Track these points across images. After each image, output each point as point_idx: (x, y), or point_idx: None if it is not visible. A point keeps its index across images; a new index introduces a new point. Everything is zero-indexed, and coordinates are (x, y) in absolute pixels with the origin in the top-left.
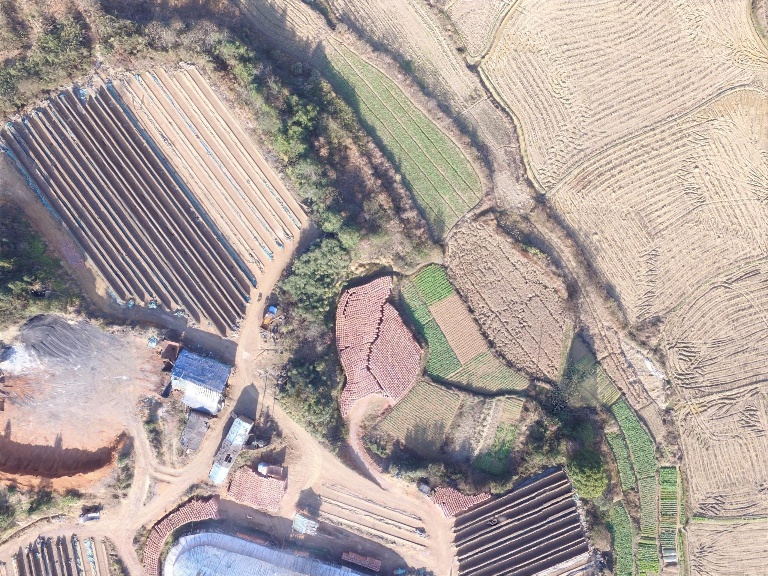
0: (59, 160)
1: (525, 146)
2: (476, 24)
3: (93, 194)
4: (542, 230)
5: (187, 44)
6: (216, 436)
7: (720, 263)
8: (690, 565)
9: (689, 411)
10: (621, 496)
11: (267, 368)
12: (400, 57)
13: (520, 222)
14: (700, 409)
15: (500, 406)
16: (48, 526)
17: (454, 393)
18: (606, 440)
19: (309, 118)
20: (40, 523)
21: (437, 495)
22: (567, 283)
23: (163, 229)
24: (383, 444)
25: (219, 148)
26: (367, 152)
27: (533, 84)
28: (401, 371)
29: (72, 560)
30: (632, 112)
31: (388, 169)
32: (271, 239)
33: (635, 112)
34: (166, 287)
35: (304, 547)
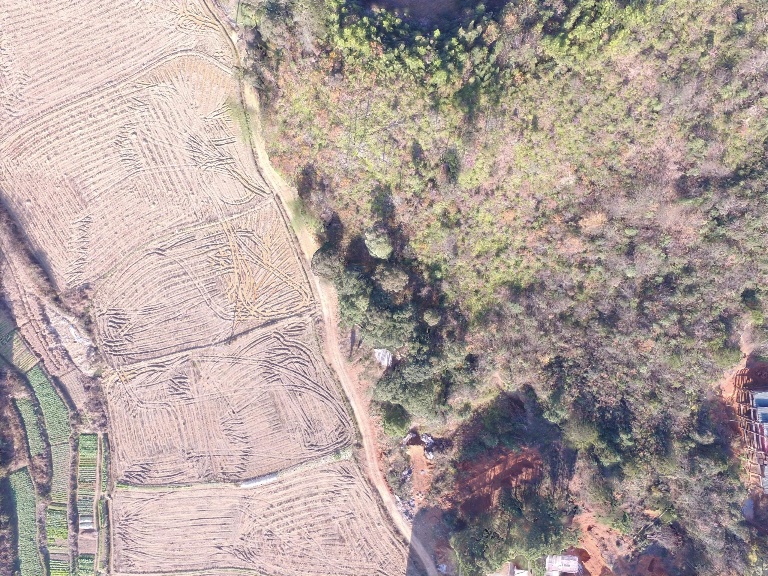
0: None
1: None
2: None
3: None
4: None
5: None
6: None
7: (154, 230)
8: (115, 533)
9: (118, 378)
10: (26, 462)
11: None
12: None
13: None
14: (129, 376)
15: None
16: None
17: None
18: (13, 406)
19: None
20: None
21: None
22: None
23: None
24: None
25: None
26: None
27: None
28: None
29: None
30: (70, 79)
31: None
32: None
33: (73, 78)
34: None
35: None
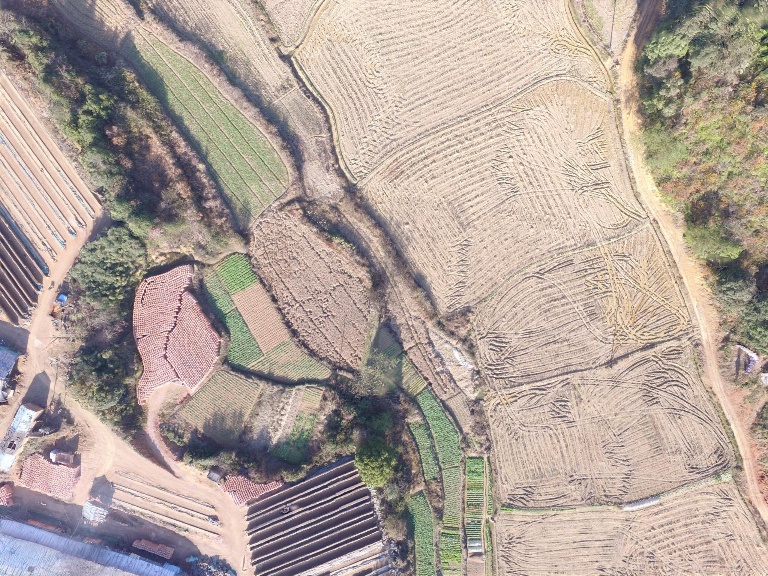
0: None
1: (337, 136)
2: (290, 14)
3: None
4: (351, 220)
5: None
6: (7, 423)
7: (533, 253)
8: (498, 556)
9: (499, 401)
10: (422, 486)
11: (59, 356)
12: (212, 47)
13: (328, 212)
14: (510, 400)
15: (299, 395)
16: None
17: (253, 382)
18: (408, 430)
19: (102, 107)
20: None
21: (227, 483)
22: (372, 273)
23: None
24: (181, 432)
25: (14, 137)
26: (171, 141)
27: (347, 74)
28: (198, 360)
29: None
30: (446, 102)
31: (191, 158)
32: (64, 228)
33: (449, 102)
34: None
35: (98, 534)
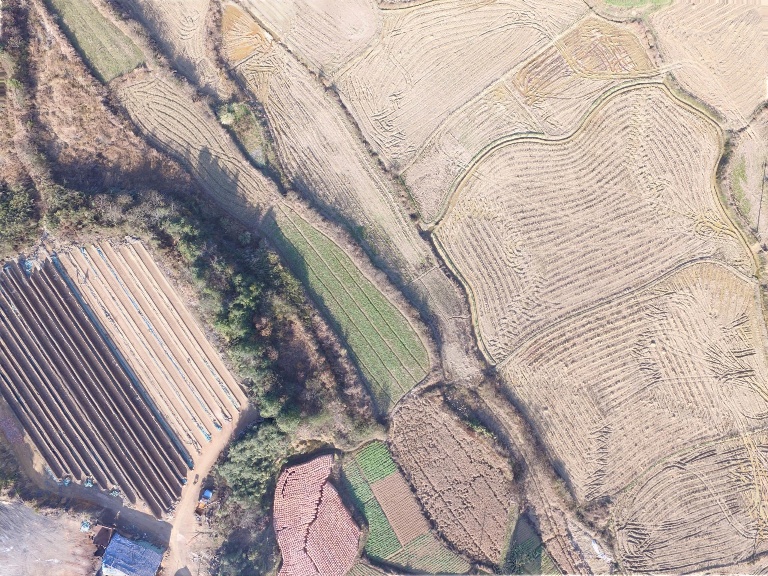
0: (2, 333)
1: (476, 316)
2: (431, 189)
3: (34, 369)
4: (490, 405)
5: (132, 220)
6: None
7: (674, 443)
8: None
9: None
10: None
11: (201, 551)
12: (352, 222)
13: (468, 397)
14: None
15: None
16: None
17: None
18: None
19: (252, 298)
20: None
21: None
22: (513, 463)
23: (102, 406)
24: None
25: (161, 325)
26: (313, 325)
27: (487, 252)
28: (338, 554)
29: None
30: (588, 284)
31: (333, 344)
32: (209, 420)
33: (591, 284)
34: (103, 466)
35: None
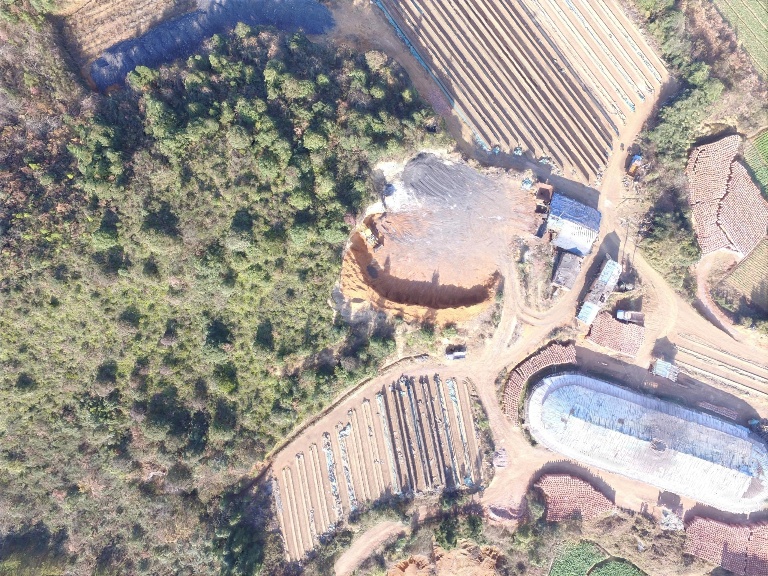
0: None
1: None
2: None
3: (461, 44)
4: None
5: None
6: (579, 281)
7: None
8: None
9: None
10: None
11: (629, 216)
12: None
13: None
14: None
15: None
16: (411, 365)
17: None
18: None
19: None
20: (403, 362)
21: None
22: None
23: None
24: (730, 299)
25: (581, 4)
26: (709, 17)
27: None
28: (751, 227)
29: (435, 399)
30: None
31: (731, 34)
32: (633, 91)
33: None
34: (532, 135)
35: (658, 395)
